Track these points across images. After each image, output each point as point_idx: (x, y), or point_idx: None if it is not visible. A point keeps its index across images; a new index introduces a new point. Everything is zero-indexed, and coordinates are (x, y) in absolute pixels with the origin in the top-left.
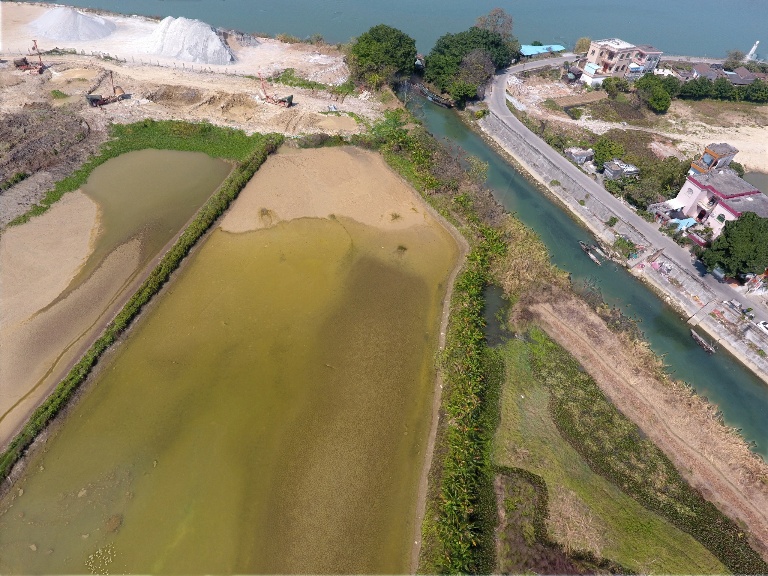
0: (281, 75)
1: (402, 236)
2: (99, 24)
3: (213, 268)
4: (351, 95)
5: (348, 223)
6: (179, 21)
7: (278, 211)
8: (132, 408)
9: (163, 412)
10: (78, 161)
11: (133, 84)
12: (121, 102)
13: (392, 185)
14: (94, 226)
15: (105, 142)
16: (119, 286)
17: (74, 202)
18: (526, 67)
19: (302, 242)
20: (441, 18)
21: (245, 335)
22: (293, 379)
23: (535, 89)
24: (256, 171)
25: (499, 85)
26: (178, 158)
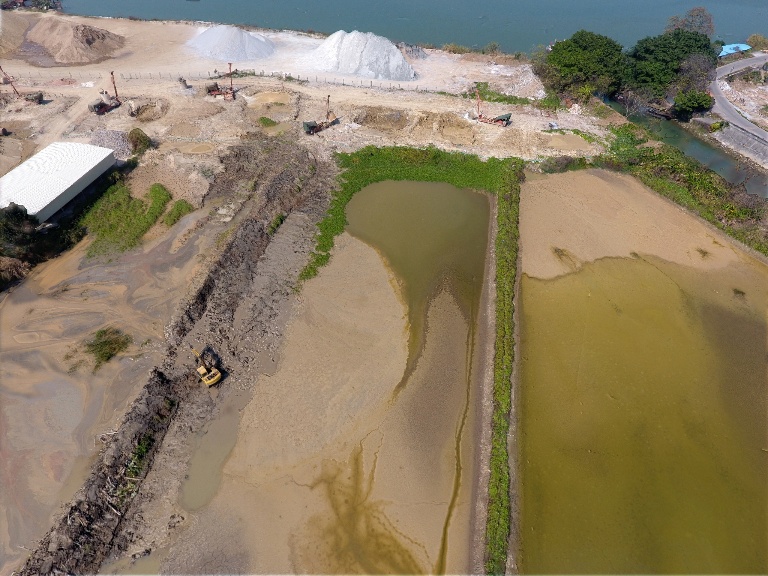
0: (475, 90)
1: (728, 277)
2: (261, 41)
3: (551, 325)
4: (560, 109)
5: (658, 262)
6: (354, 35)
7: (573, 250)
8: (583, 516)
9: (621, 521)
10: (324, 198)
11: (332, 107)
12: (334, 128)
13: (672, 214)
14: (389, 276)
15: (339, 174)
16: (464, 351)
17: (350, 247)
18: (727, 70)
19: (625, 288)
20: (591, 19)
21: (644, 412)
22: (739, 470)
23: (744, 94)
24: (518, 203)
25: (715, 92)
26: (422, 190)
